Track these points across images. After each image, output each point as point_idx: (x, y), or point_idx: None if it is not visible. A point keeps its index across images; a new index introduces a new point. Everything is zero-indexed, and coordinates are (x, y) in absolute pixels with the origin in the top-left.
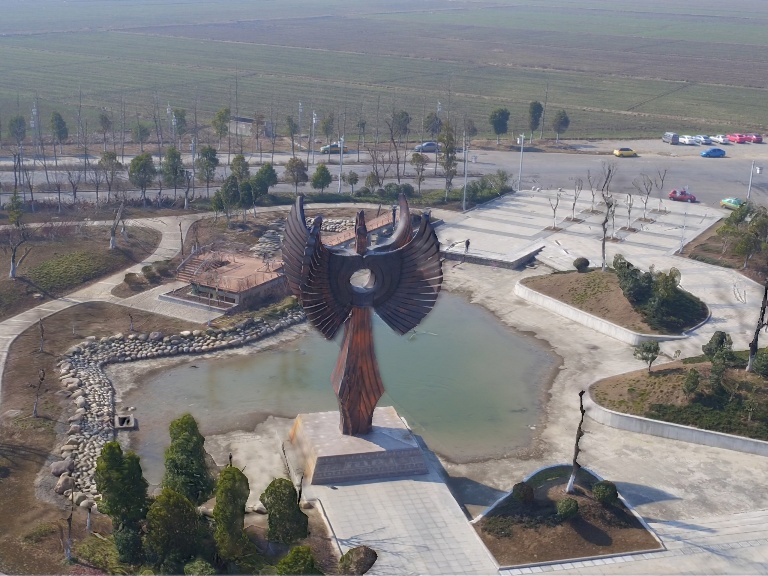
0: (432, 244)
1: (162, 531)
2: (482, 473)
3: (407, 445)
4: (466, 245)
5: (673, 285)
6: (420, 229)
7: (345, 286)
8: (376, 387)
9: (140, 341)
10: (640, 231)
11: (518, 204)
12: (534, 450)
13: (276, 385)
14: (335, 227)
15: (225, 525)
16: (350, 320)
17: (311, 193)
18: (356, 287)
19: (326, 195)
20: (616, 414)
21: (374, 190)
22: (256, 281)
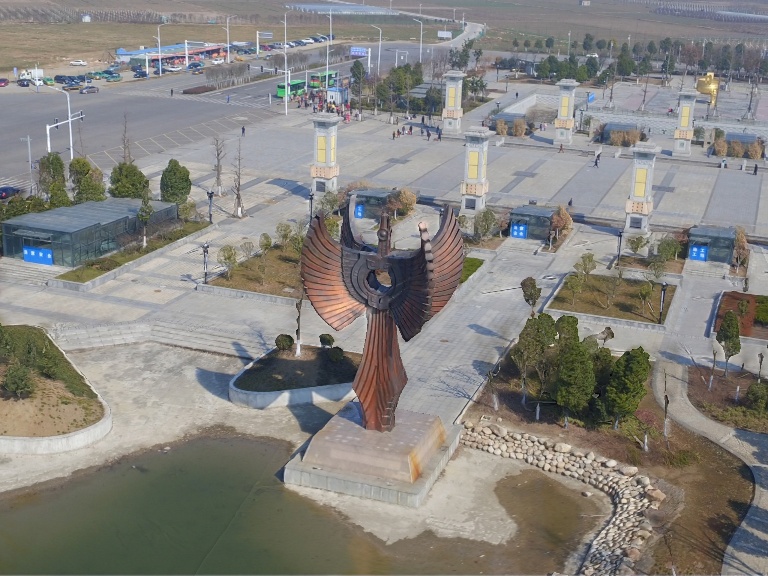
0: None
1: None
2: (285, 429)
3: (358, 404)
4: None
5: None
6: None
7: None
8: None
9: None
10: None
11: None
12: (210, 432)
13: None
14: None
15: None
16: None
17: None
18: None
19: None
20: None
21: None
22: None
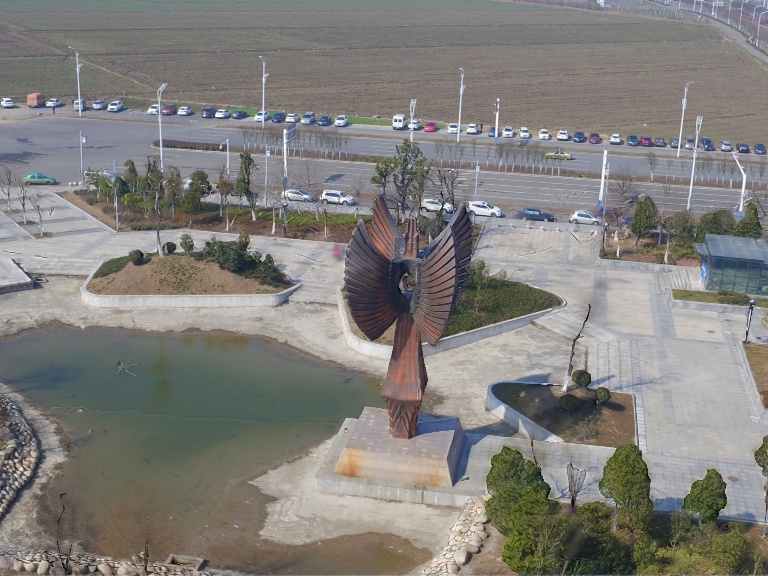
0: (468, 229)
1: None
2: None
3: (452, 420)
4: None
5: None
6: (458, 218)
7: None
8: None
9: None
10: (38, 222)
11: None
12: (428, 395)
13: (171, 463)
14: None
15: None
16: (414, 325)
17: None
18: (403, 293)
19: None
20: None
21: None
22: None
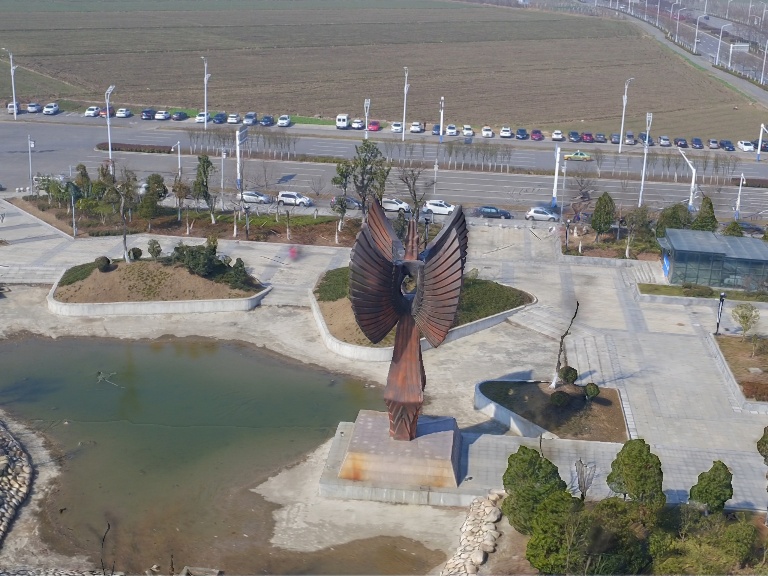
0: (464, 230)
1: None
2: None
3: (449, 420)
4: None
5: None
6: (455, 219)
7: None
8: (423, 382)
9: None
10: None
11: None
12: None
13: (168, 473)
14: None
15: None
16: (414, 327)
17: None
18: None
19: None
20: None
21: None
22: None
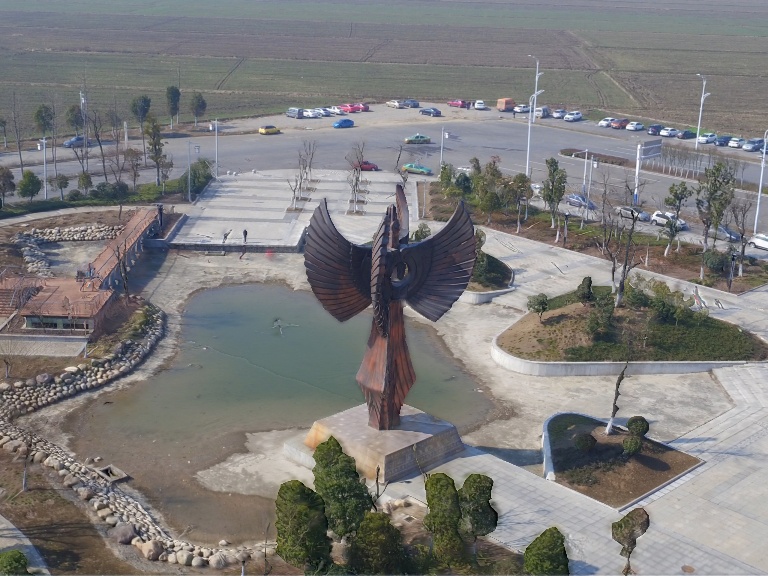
0: (468, 229)
1: (381, 556)
2: (489, 439)
3: (444, 426)
4: (244, 235)
5: (480, 245)
6: (455, 216)
7: (389, 282)
8: (409, 377)
9: (31, 387)
10: (368, 202)
11: (233, 190)
12: (504, 409)
13: (213, 403)
14: (83, 235)
15: (454, 531)
16: None
17: (17, 203)
18: None
19: (36, 203)
20: (543, 364)
21: (87, 192)
22: (100, 302)
